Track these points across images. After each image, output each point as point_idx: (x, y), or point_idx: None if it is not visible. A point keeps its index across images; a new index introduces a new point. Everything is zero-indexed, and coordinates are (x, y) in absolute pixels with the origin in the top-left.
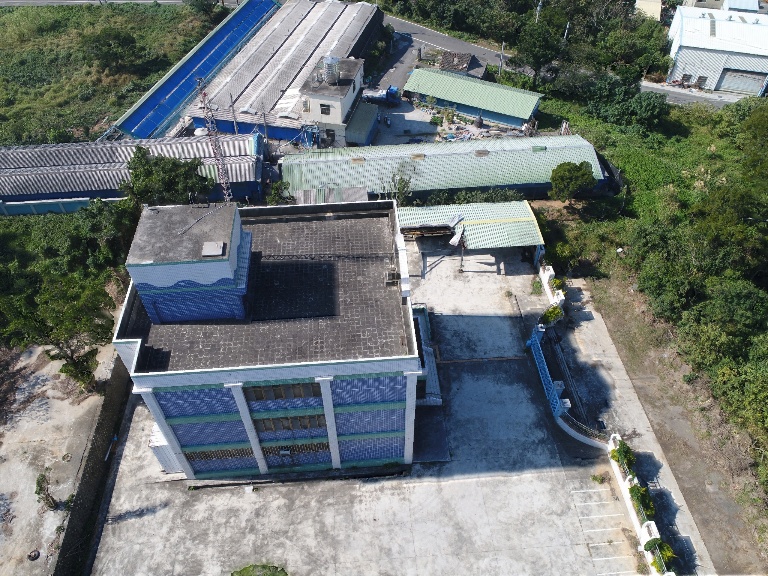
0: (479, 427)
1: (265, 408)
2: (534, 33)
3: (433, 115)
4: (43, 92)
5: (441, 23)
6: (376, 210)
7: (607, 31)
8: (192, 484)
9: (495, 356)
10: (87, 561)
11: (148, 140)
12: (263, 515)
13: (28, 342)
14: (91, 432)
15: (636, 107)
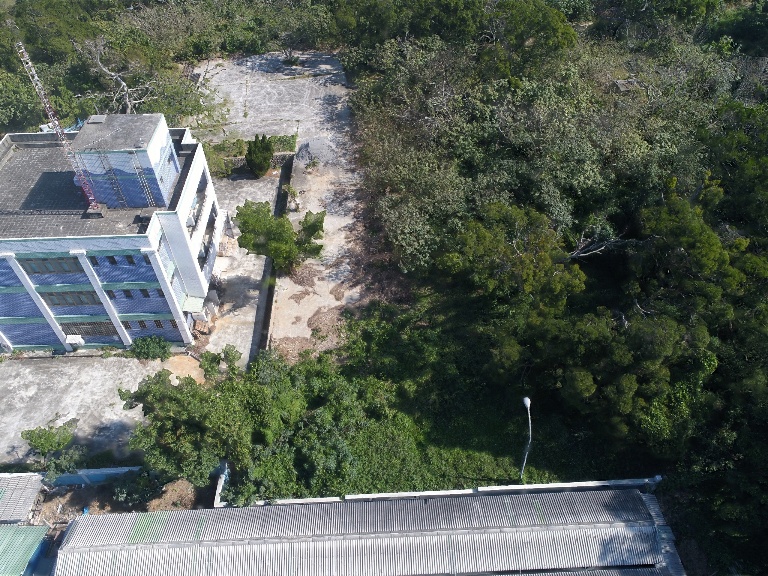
0: None
1: None
2: None
3: None
4: None
5: None
6: None
7: None
8: None
9: None
10: None
11: None
12: None
13: None
14: None
15: None
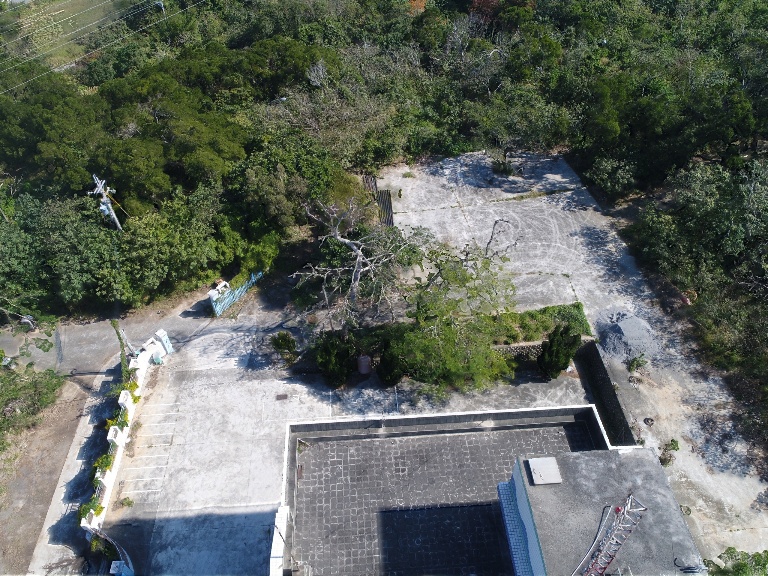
0: (228, 567)
1: None
2: None
3: None
4: None
5: None
6: None
7: None
8: None
9: None
10: None
11: None
12: None
13: None
14: None
15: None
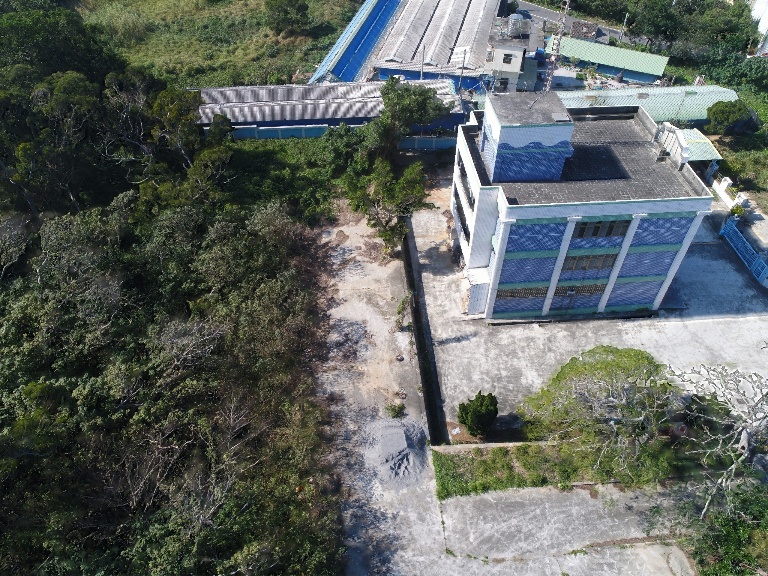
0: (701, 287)
1: (578, 246)
2: (655, 6)
3: (577, 72)
4: (232, 50)
5: (551, 2)
6: (624, 113)
7: (702, 10)
8: (490, 322)
9: (697, 241)
10: (431, 368)
11: (359, 82)
12: (554, 341)
13: (367, 207)
14: (404, 284)
15: (746, 70)
